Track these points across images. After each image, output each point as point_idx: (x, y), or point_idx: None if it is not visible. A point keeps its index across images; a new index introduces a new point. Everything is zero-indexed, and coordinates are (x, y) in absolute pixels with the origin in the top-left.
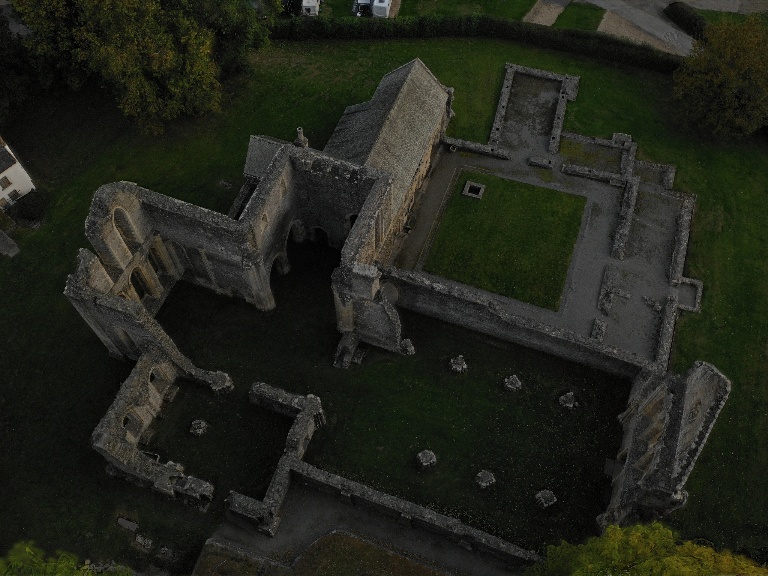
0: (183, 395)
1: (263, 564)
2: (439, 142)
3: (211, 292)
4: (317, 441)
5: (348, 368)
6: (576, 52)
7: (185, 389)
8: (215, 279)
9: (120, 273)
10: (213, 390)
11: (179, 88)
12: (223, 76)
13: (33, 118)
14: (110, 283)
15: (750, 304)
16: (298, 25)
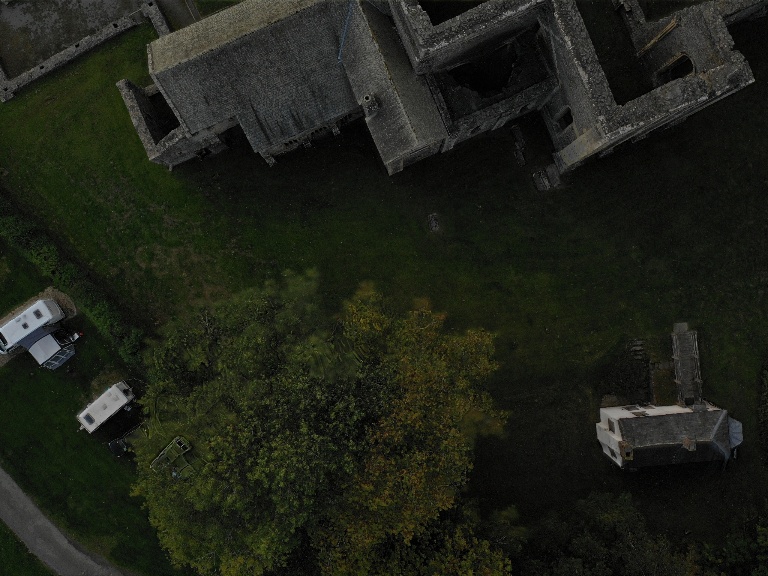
0: None
1: None
2: None
3: None
4: None
5: None
6: None
7: None
8: None
9: None
10: None
11: None
12: None
13: (535, 517)
14: None
15: None
16: None
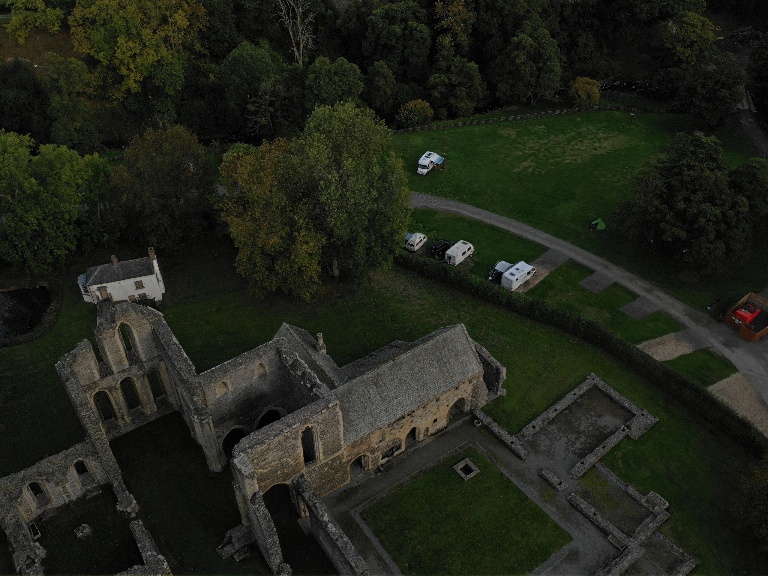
0: (99, 499)
1: None
2: (470, 411)
3: (188, 432)
4: None
5: (225, 559)
6: (672, 395)
7: (104, 495)
8: None
9: (110, 374)
10: (116, 508)
11: None
12: (341, 278)
13: (203, 253)
14: (96, 377)
15: None
16: (428, 265)
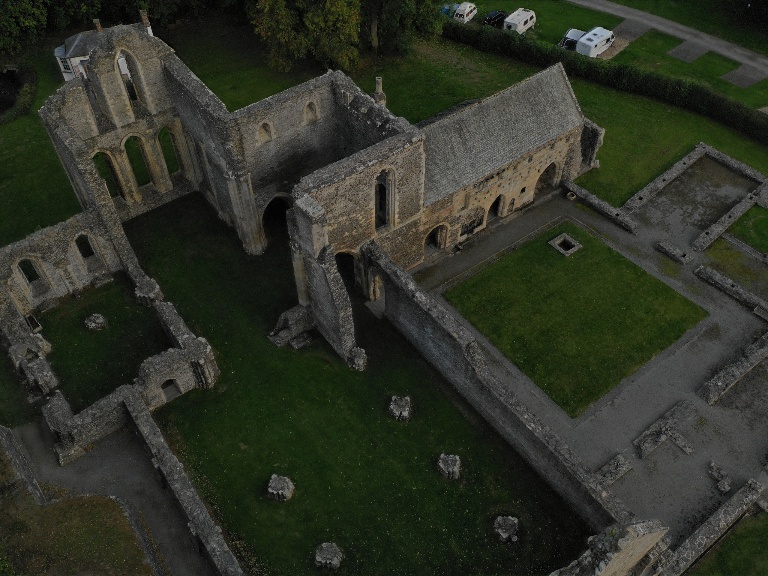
0: (111, 287)
1: (17, 481)
2: (559, 184)
3: (215, 213)
4: (188, 399)
5: (280, 347)
6: None
7: (118, 283)
8: (217, 195)
9: (112, 128)
10: (135, 294)
11: (315, 26)
12: (381, 49)
13: (206, 32)
14: (93, 130)
15: None
16: (486, 33)
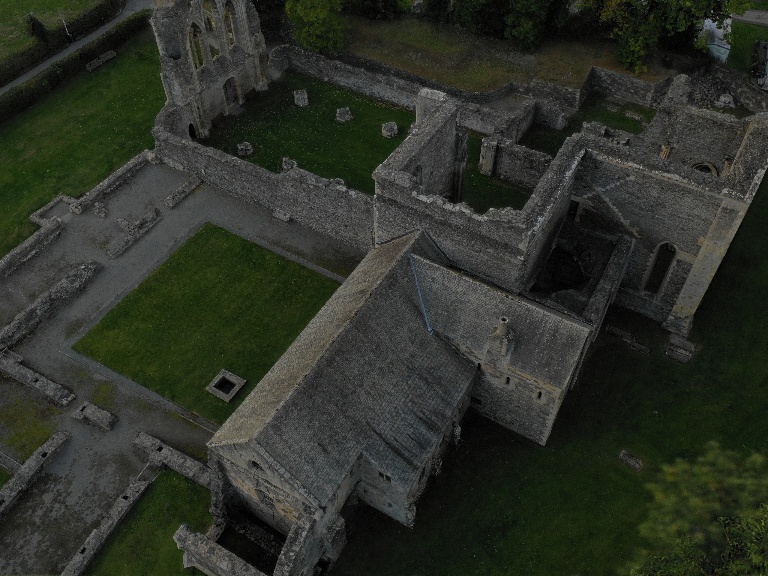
0: None
1: None
2: None
3: None
4: None
5: None
6: None
7: None
8: None
9: None
10: None
11: None
12: None
13: None
14: None
15: (3, 190)
16: None
